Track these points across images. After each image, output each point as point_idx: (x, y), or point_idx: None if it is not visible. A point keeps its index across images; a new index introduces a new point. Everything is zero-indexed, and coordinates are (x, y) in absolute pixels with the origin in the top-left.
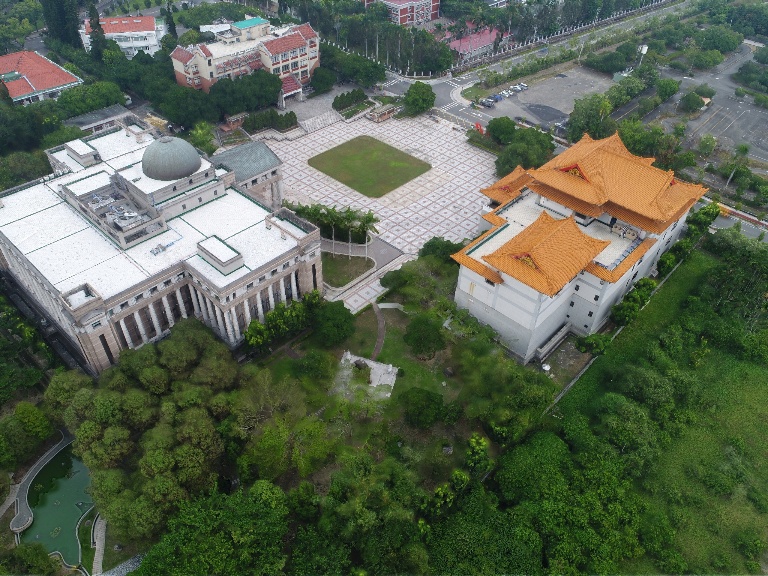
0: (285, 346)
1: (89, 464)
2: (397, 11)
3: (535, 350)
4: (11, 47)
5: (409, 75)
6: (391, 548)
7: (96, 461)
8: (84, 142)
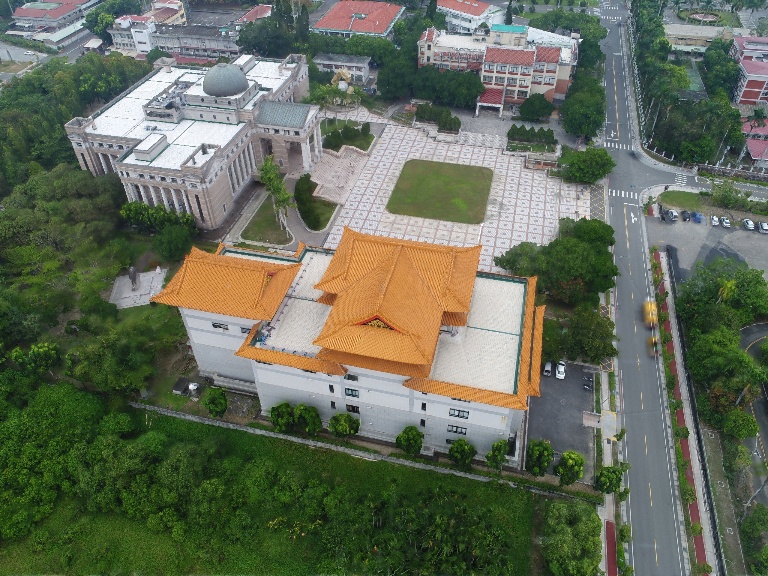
0: None
1: (1, 202)
2: (744, 80)
3: None
4: (411, 1)
5: (650, 148)
6: None
7: (4, 204)
8: (250, 58)
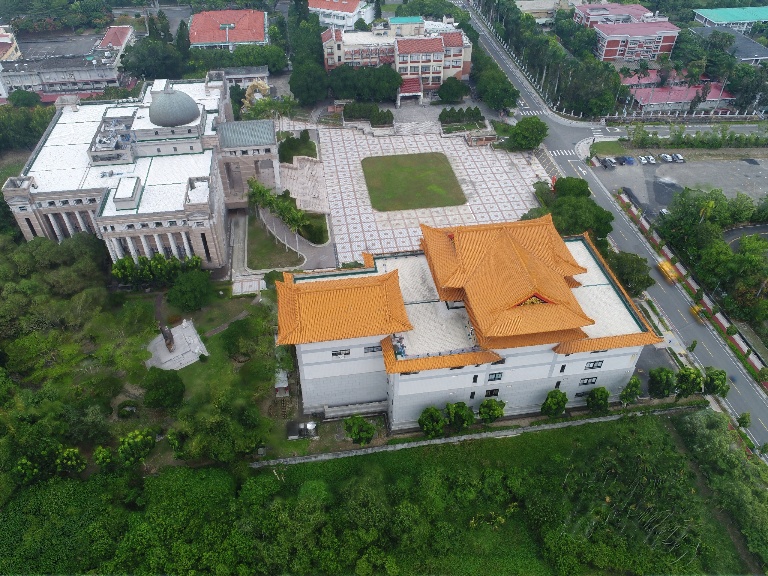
0: (162, 293)
1: None
2: (604, 42)
3: (323, 406)
4: (264, 6)
5: (558, 110)
6: (3, 467)
7: None
8: (166, 82)
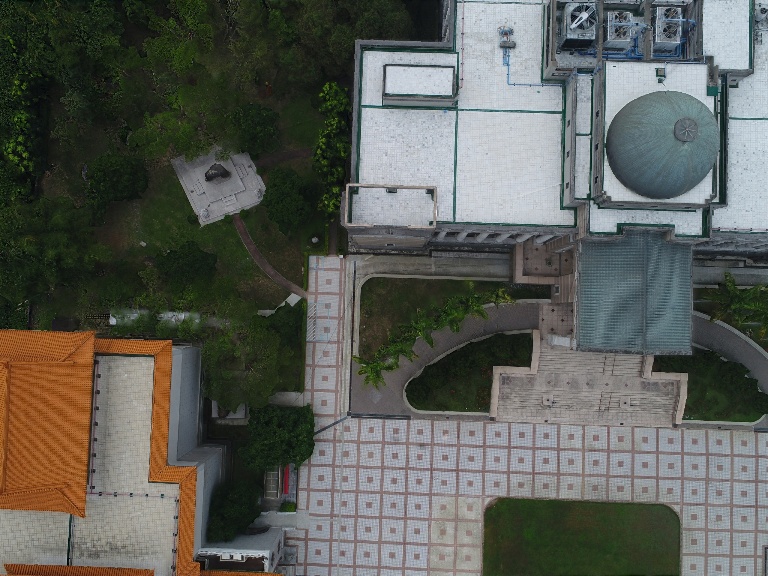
0: None
1: None
2: None
3: None
4: None
5: None
6: None
7: None
8: None
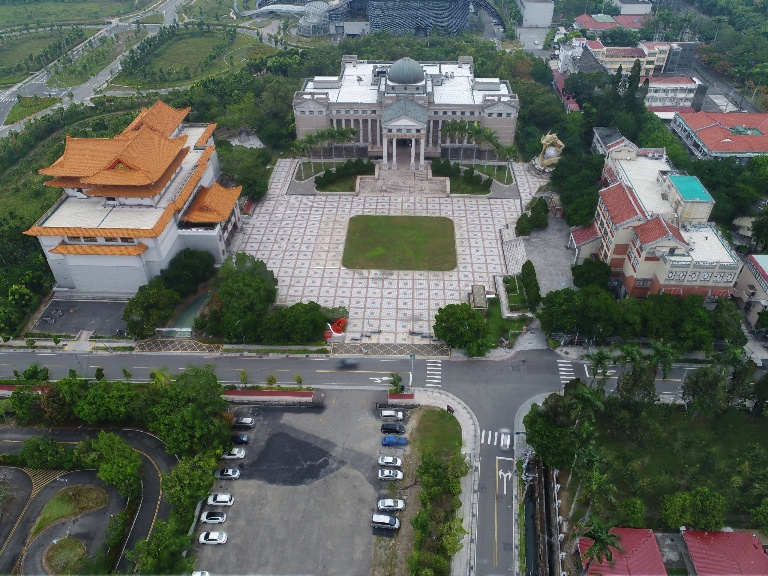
0: None
1: None
2: None
3: None
4: None
5: None
6: None
7: None
8: (493, 82)
